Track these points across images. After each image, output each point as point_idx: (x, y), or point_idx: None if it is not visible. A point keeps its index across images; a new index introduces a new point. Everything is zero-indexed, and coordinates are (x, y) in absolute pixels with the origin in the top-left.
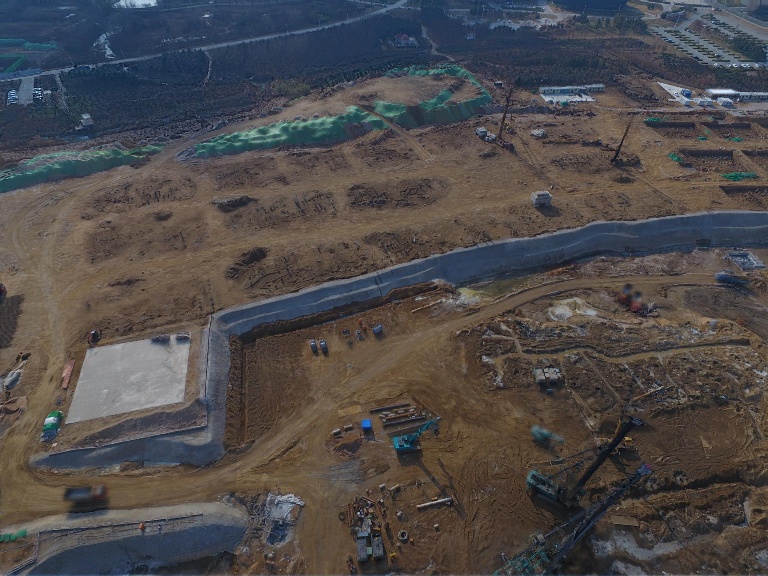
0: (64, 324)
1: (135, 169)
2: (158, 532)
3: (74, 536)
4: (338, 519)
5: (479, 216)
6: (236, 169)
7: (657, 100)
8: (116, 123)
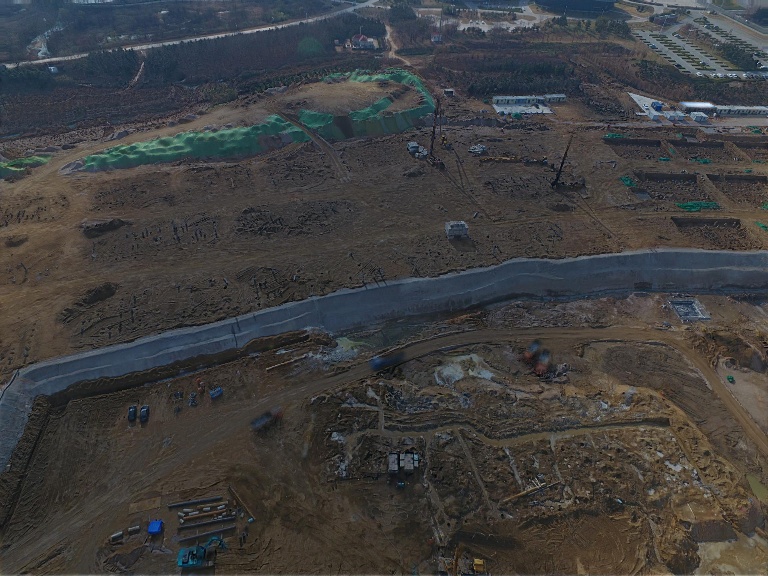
0: None
1: (9, 183)
2: None
3: None
4: None
5: (380, 249)
6: (122, 186)
7: (623, 113)
8: (15, 129)
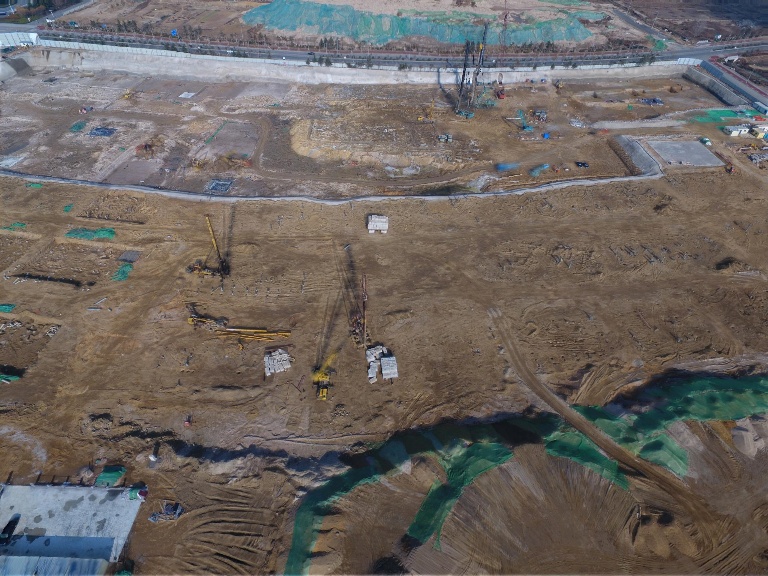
0: (762, 180)
1: None
2: None
3: None
4: (553, 120)
5: (452, 223)
6: None
7: None
8: None
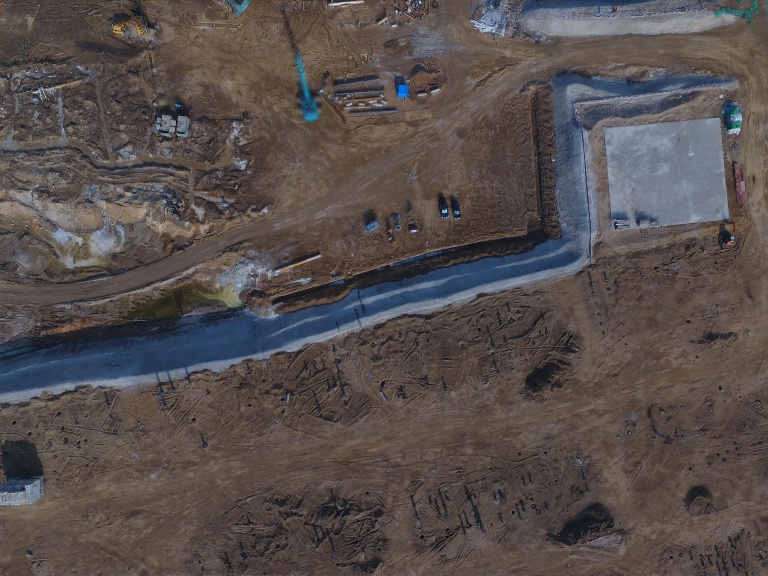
0: None
1: None
2: (601, 7)
3: (673, 7)
4: (439, 3)
5: (158, 455)
6: None
7: None
8: None
